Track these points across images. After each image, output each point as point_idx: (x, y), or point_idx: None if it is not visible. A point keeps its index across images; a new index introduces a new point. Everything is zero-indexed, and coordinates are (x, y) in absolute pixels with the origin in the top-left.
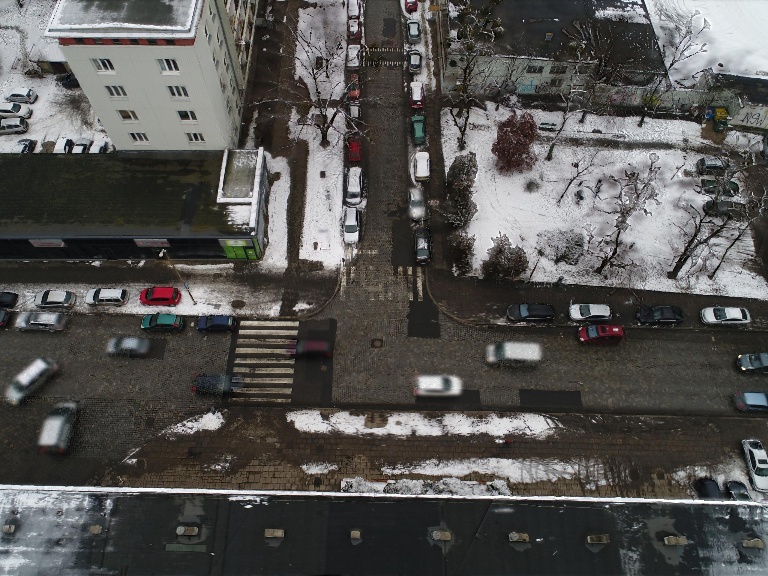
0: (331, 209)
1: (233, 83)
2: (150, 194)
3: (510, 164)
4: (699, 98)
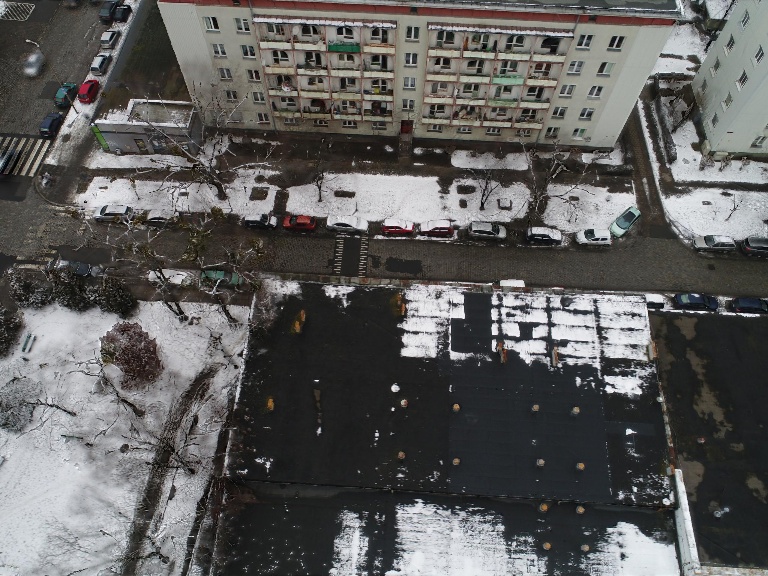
0: (140, 200)
1: (266, 100)
2: (161, 63)
3: None
4: None
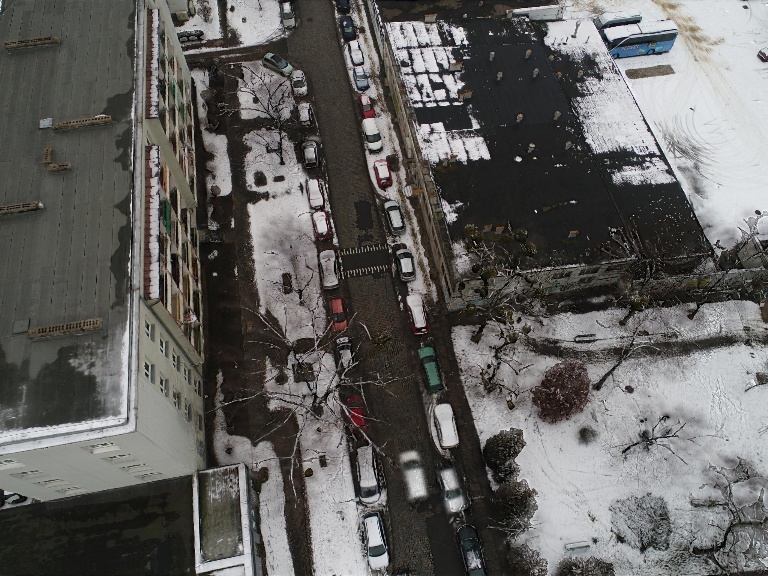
0: (344, 516)
1: (187, 367)
2: (100, 570)
3: (557, 413)
4: (754, 275)
